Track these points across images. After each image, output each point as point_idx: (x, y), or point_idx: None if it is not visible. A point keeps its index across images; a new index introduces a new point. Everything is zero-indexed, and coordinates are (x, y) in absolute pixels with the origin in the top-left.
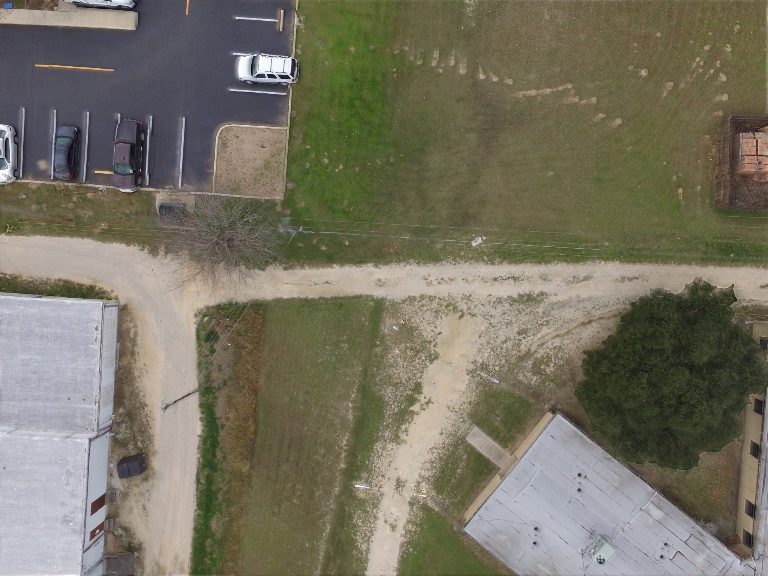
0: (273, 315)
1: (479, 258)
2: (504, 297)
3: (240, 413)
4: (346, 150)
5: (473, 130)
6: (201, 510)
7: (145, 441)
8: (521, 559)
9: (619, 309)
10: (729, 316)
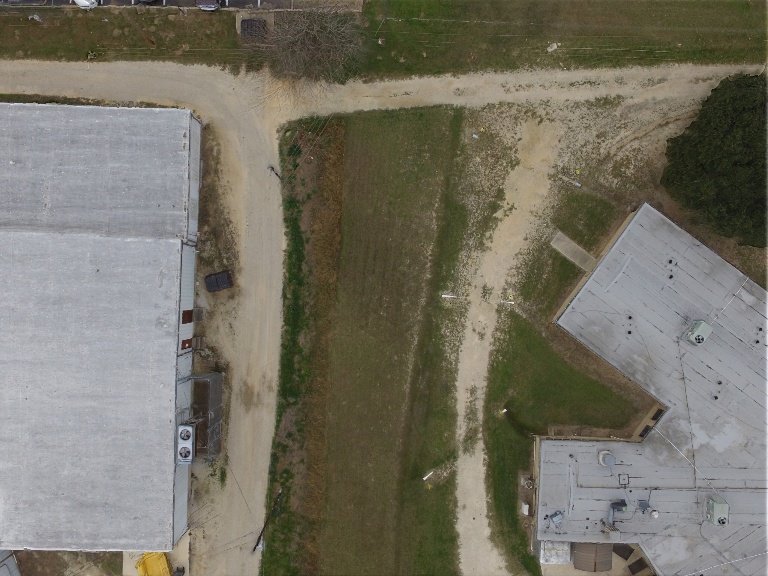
0: (354, 127)
1: (555, 64)
2: (581, 101)
3: (325, 225)
4: None
5: None
6: (288, 325)
7: (230, 258)
8: (617, 350)
9: (695, 110)
10: None
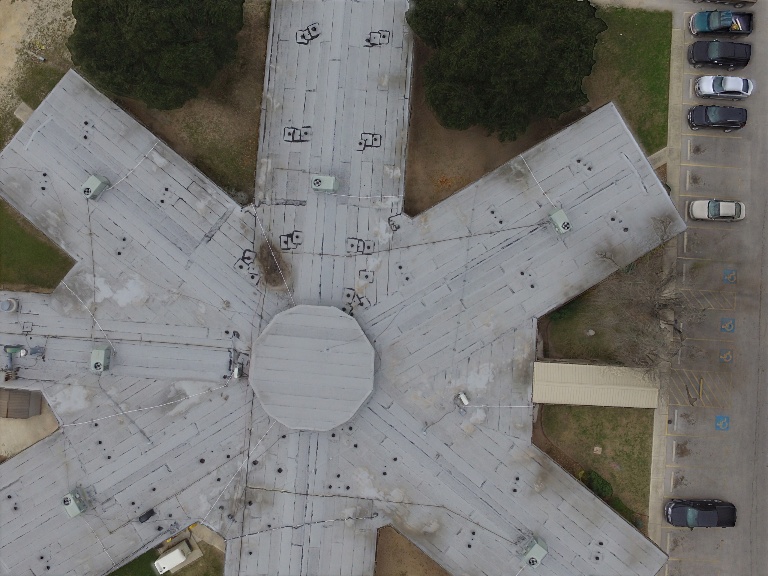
0: None
1: None
2: None
3: None
4: None
5: None
6: None
7: None
8: (32, 205)
9: None
10: None
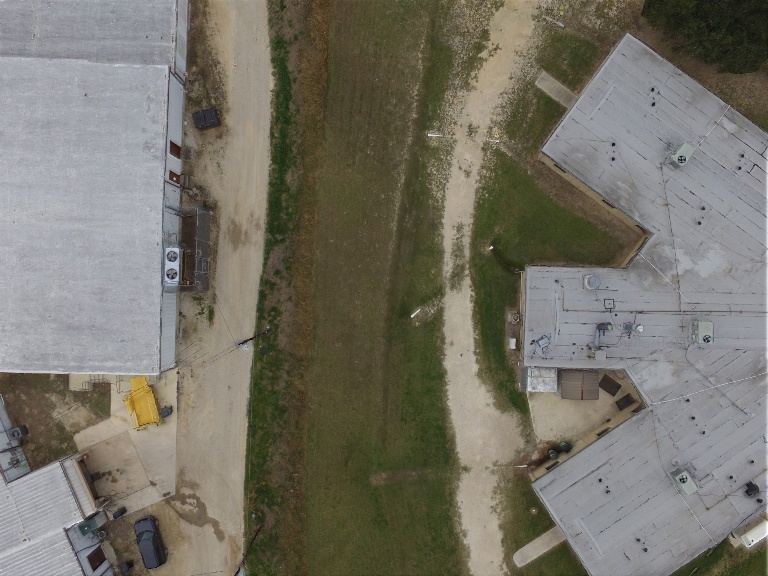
0: None
1: None
2: None
3: (312, 64)
4: None
5: None
6: (276, 164)
7: (218, 97)
8: (601, 177)
9: None
10: None
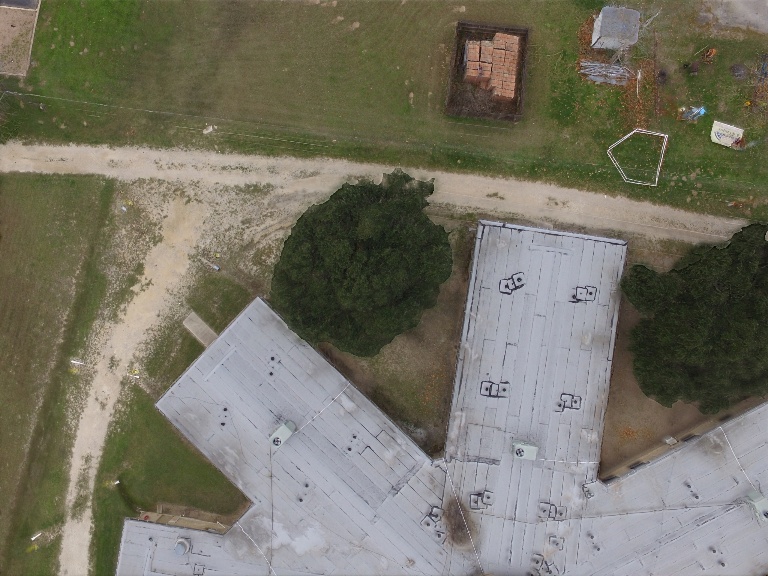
0: (8, 187)
1: (210, 146)
2: (231, 186)
3: None
4: (92, 35)
5: (215, 24)
6: None
7: None
8: (209, 440)
9: None
10: (414, 203)
